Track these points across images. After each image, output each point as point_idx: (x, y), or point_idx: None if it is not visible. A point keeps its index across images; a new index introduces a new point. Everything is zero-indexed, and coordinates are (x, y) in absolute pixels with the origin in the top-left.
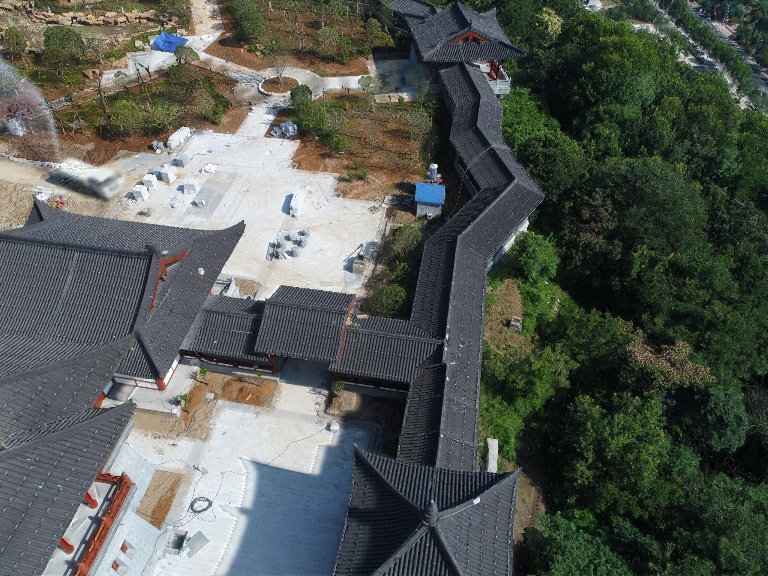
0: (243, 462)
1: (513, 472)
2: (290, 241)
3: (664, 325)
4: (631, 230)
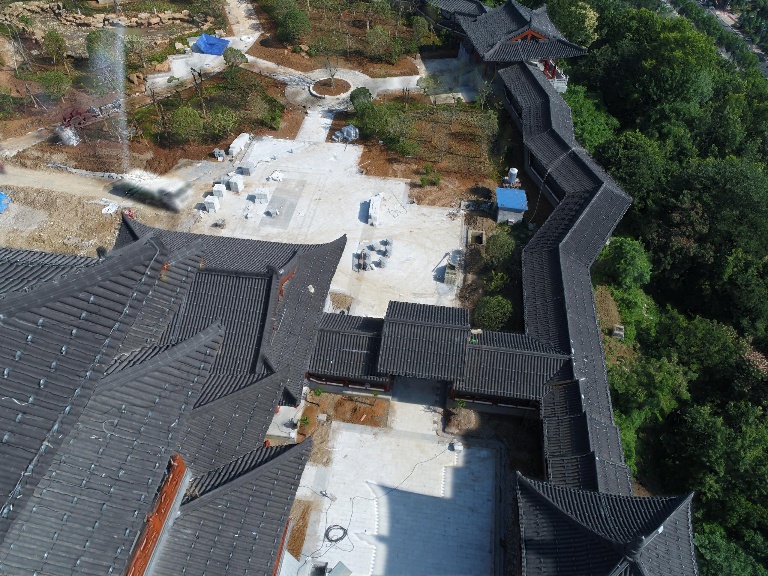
0: (371, 487)
1: (686, 497)
2: (374, 251)
3: (765, 330)
4: (724, 233)
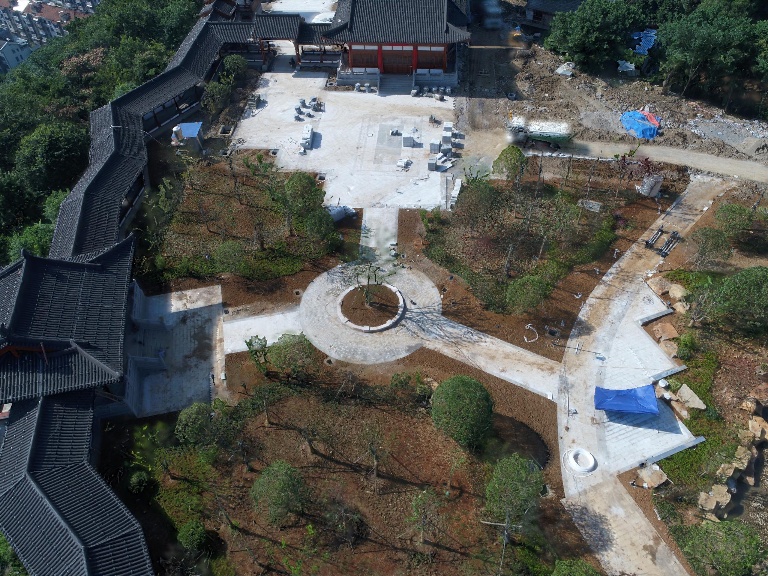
0: None
1: None
2: None
3: None
4: None
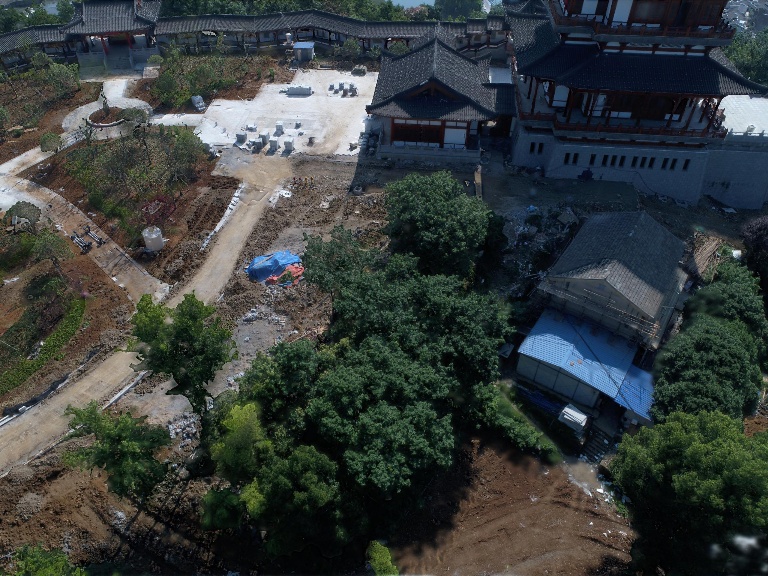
0: None
1: None
2: (339, 92)
3: None
4: (341, 3)
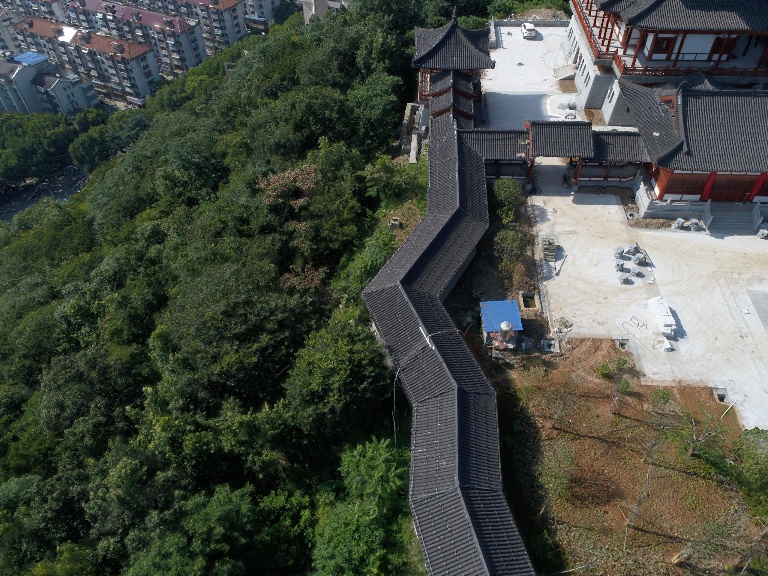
0: None
1: None
2: None
3: None
4: None
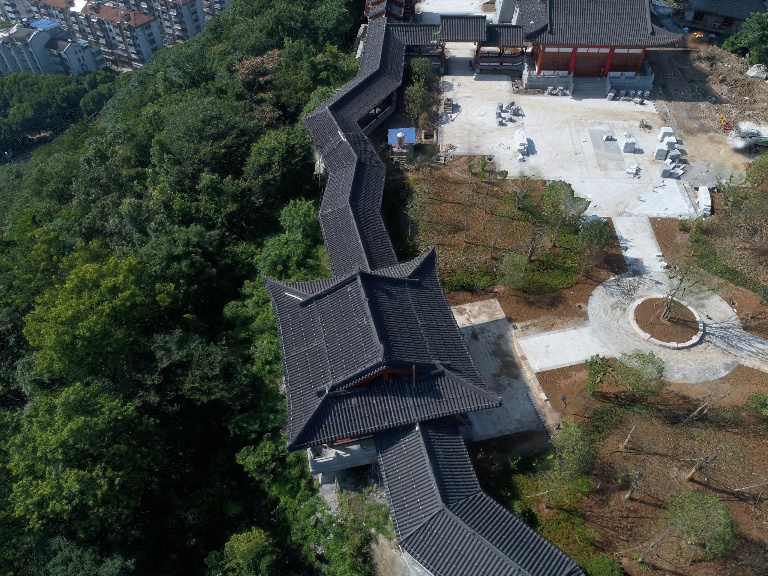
0: None
1: None
2: None
3: None
4: None
